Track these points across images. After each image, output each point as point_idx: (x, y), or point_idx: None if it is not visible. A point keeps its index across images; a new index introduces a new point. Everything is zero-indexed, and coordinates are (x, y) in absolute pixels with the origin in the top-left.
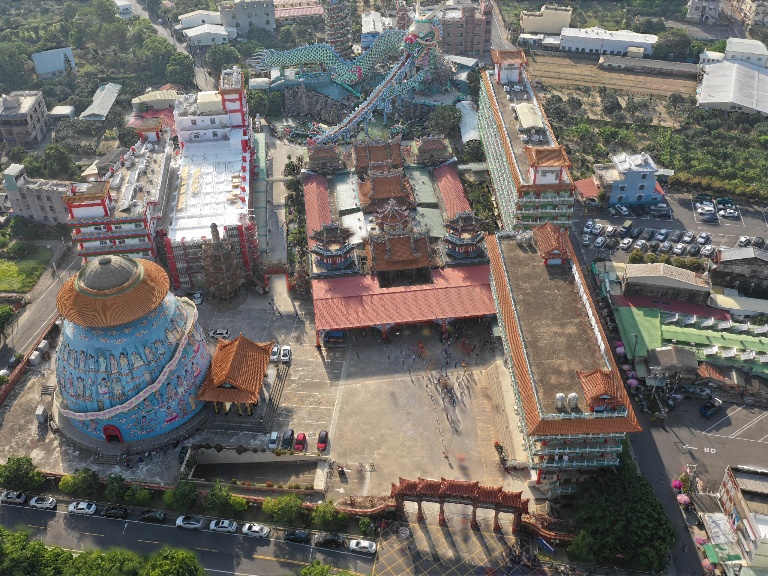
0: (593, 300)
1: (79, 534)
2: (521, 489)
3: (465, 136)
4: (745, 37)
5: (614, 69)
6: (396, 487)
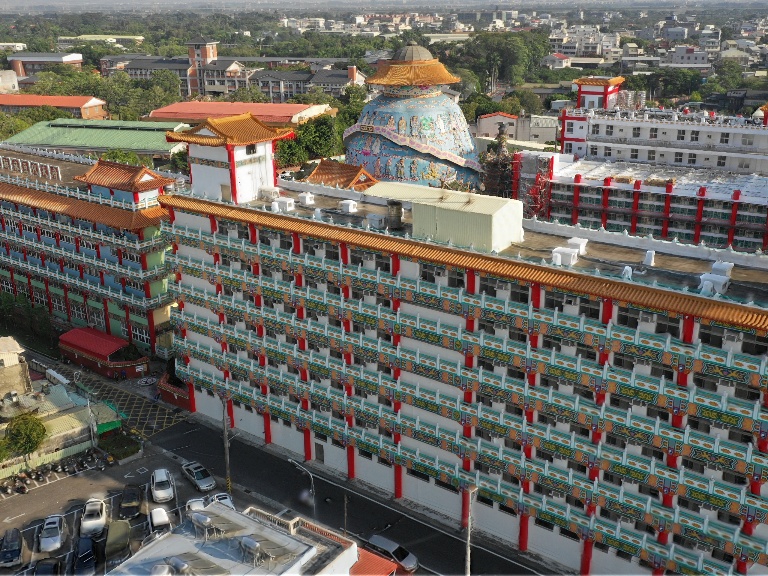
0: None
1: (306, 177)
2: None
3: None
4: None
5: None
6: None
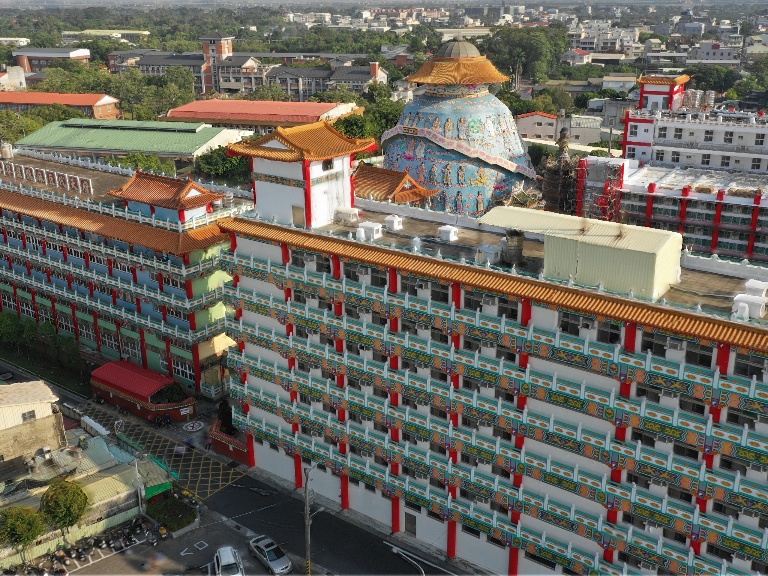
0: None
1: None
2: None
3: None
4: None
5: None
6: None
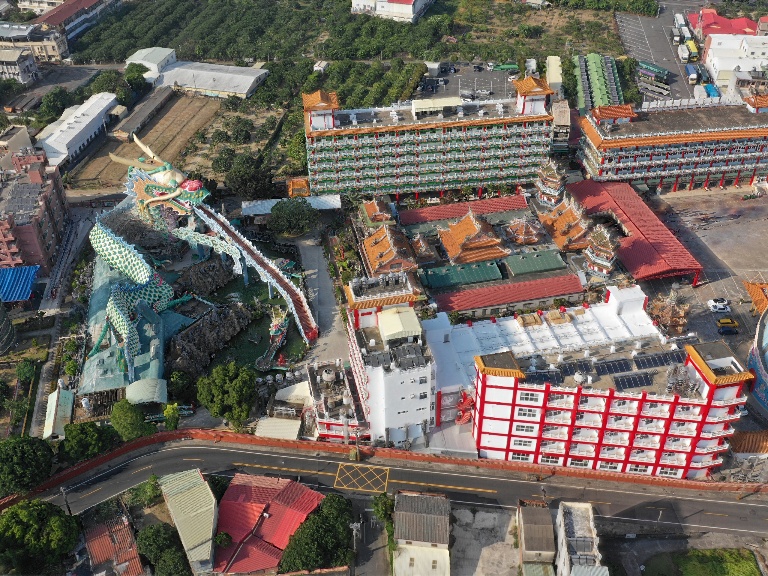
0: (564, 161)
1: None
2: None
3: (329, 205)
4: (84, 67)
5: (138, 134)
6: None
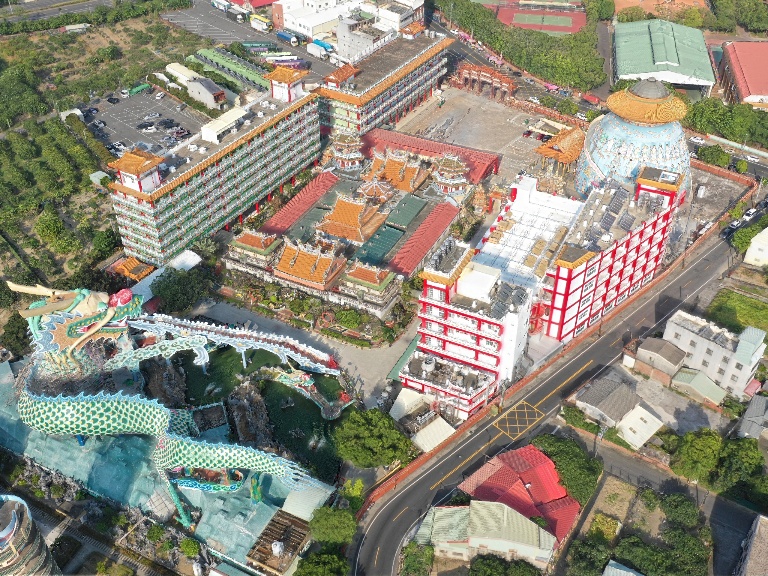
0: None
1: None
2: (446, 95)
3: (191, 263)
4: None
5: None
6: (513, 87)
